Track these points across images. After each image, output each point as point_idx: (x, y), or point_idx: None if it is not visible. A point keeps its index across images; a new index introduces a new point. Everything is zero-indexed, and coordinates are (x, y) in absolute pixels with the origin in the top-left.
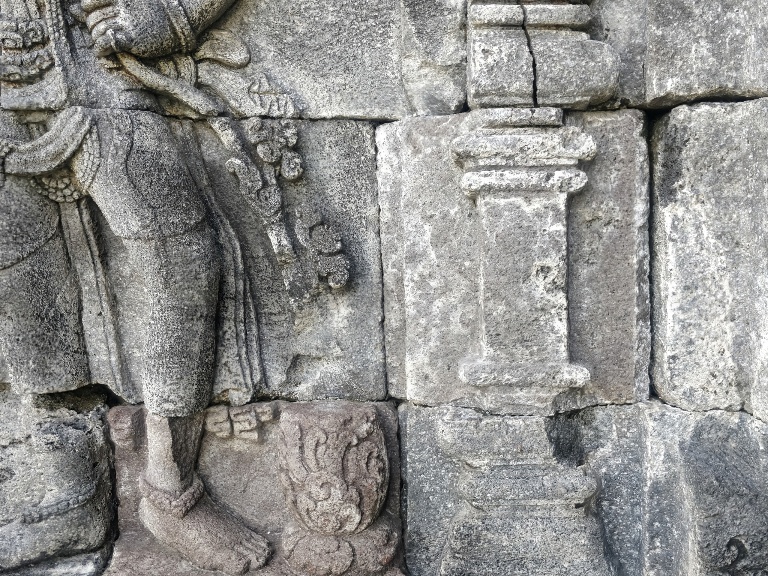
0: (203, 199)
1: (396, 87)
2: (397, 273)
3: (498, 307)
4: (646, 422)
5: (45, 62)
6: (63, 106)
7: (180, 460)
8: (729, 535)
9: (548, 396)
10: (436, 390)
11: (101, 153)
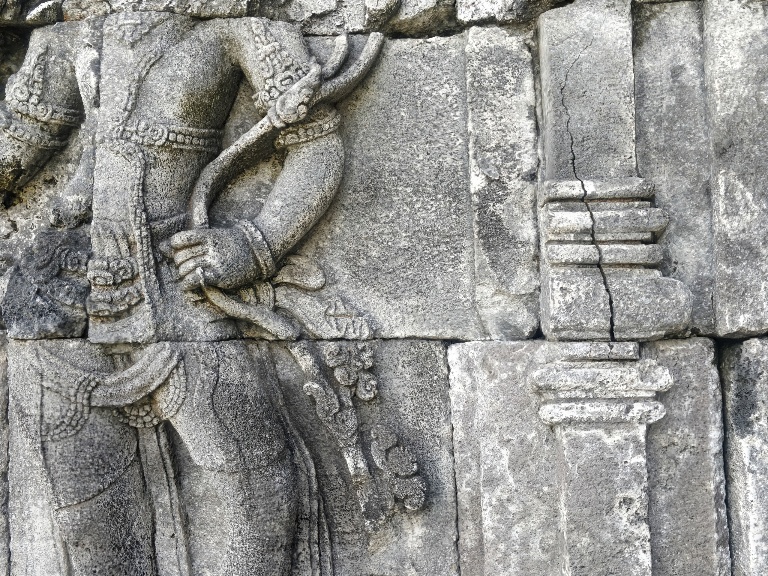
0: (279, 419)
1: (468, 309)
2: (471, 492)
3: (582, 539)
4: None
5: (134, 298)
6: (150, 340)
7: None
8: None
9: None
10: None
11: (187, 387)
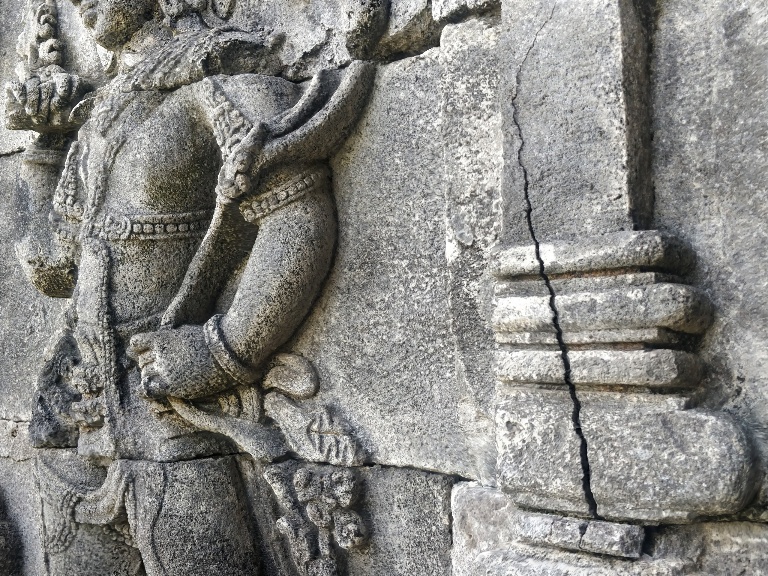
0: (269, 557)
1: None
2: None
3: None
4: None
5: (104, 409)
6: (115, 456)
7: None
8: None
9: None
10: None
11: (136, 514)
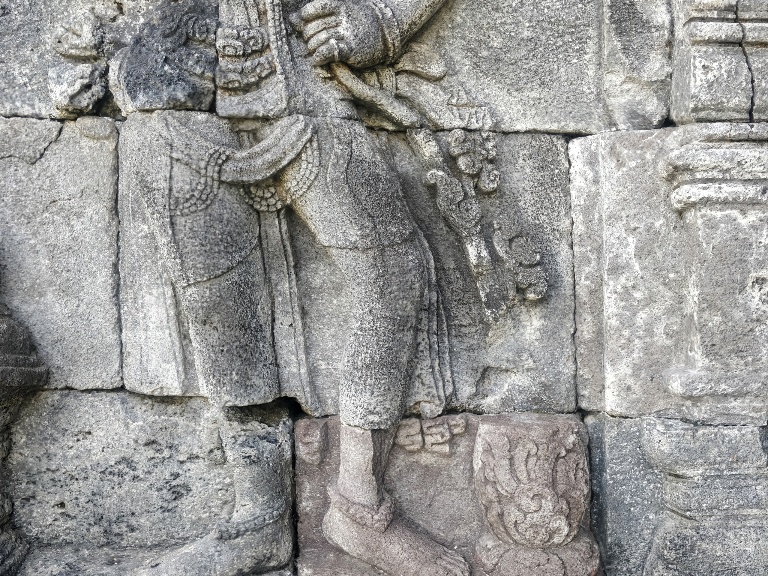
0: None
1: (592, 102)
2: (590, 285)
3: (713, 318)
4: None
5: (265, 70)
6: (281, 114)
7: (375, 474)
8: None
9: (762, 406)
10: (638, 401)
11: (320, 162)
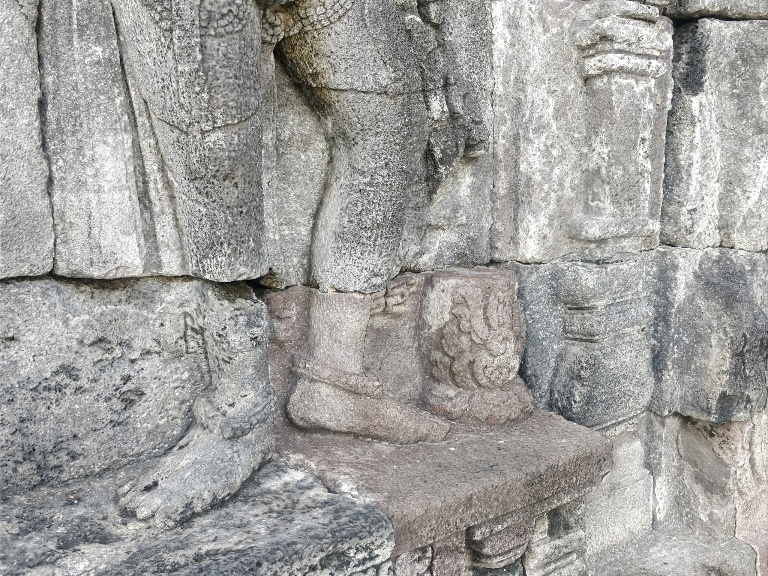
0: None
1: None
2: (505, 144)
3: (617, 172)
4: (677, 260)
5: None
6: None
7: None
8: (743, 330)
9: (639, 244)
10: (550, 248)
11: None
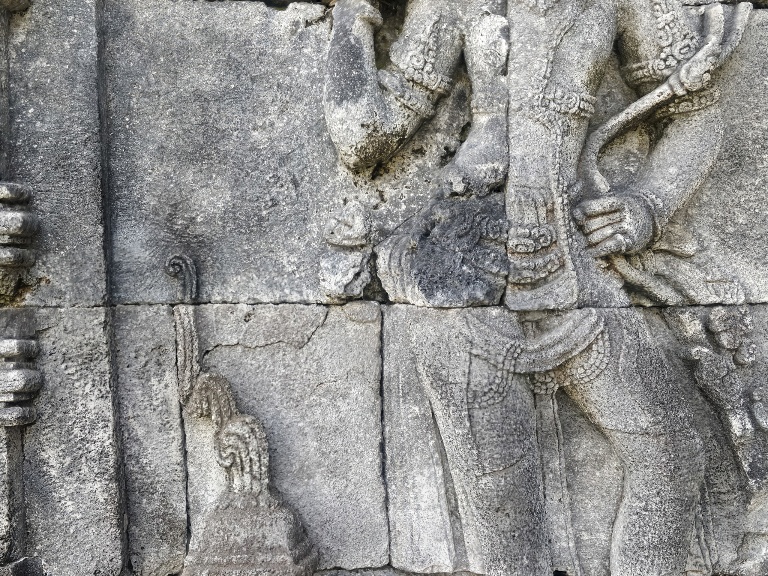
0: None
1: None
2: None
3: None
4: None
5: (555, 265)
6: (571, 307)
7: None
8: None
9: None
10: None
11: (611, 352)
